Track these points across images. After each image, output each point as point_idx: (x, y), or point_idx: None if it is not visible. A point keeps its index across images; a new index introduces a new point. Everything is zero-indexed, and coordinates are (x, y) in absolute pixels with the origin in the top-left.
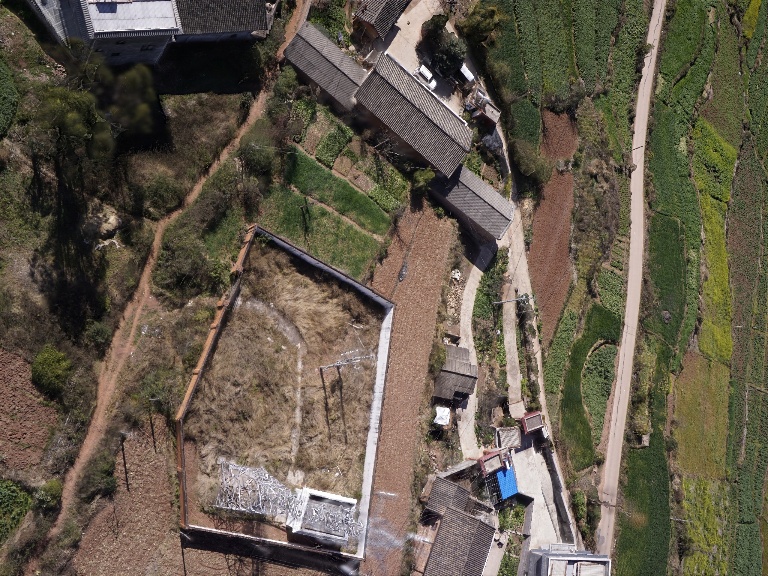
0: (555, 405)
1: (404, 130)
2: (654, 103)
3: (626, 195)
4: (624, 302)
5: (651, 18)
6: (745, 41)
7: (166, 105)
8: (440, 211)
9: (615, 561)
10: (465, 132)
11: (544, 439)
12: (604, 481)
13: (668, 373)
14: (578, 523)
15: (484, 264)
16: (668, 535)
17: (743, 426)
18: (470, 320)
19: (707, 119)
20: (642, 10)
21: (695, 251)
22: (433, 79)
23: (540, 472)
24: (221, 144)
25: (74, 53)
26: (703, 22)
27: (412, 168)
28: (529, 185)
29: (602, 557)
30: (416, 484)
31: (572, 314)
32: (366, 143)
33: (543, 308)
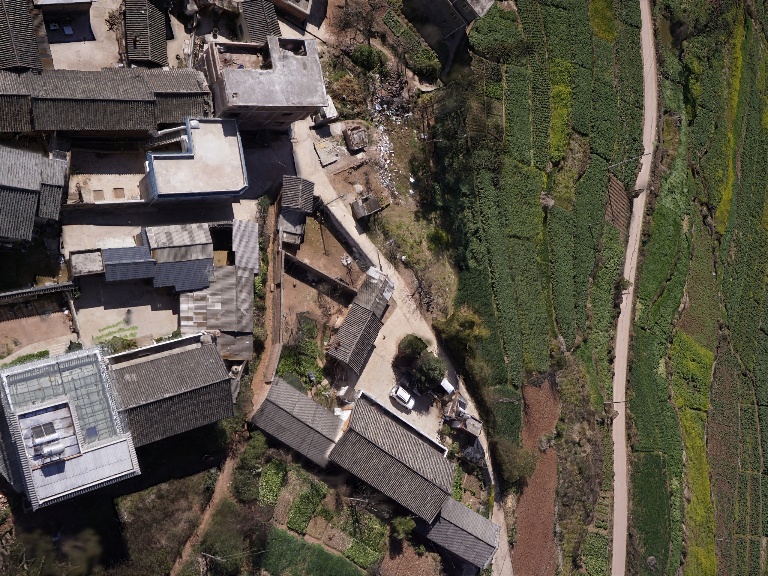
0: None
1: (382, 482)
2: (633, 337)
3: (609, 447)
4: (610, 564)
5: (627, 246)
6: (718, 237)
7: (122, 508)
8: (421, 551)
9: None
10: (446, 467)
11: None
12: None
13: None
14: None
15: None
16: None
17: None
18: None
19: (684, 329)
20: (618, 240)
21: (677, 479)
22: (411, 398)
23: None
24: (183, 541)
25: (17, 489)
26: (678, 234)
27: (391, 514)
28: None
29: None
30: None
31: None
32: (341, 494)
33: None
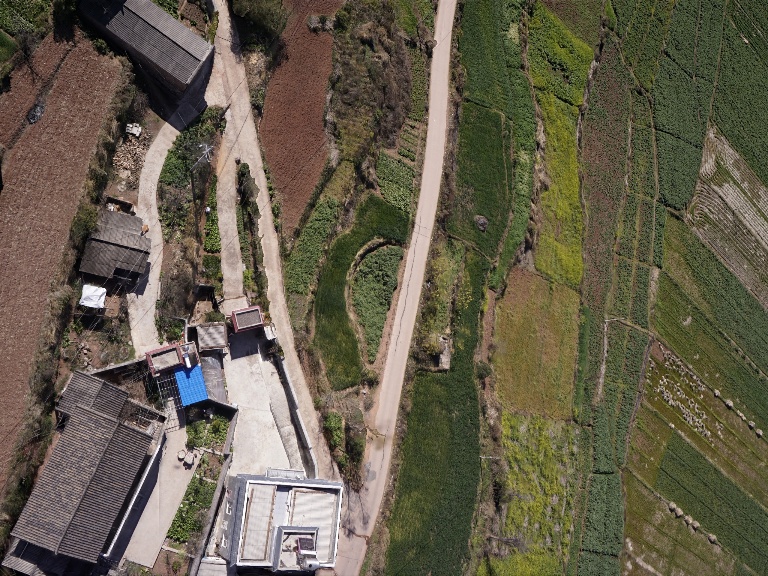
0: (302, 308)
1: None
2: None
3: (421, 74)
4: (416, 198)
5: None
6: None
7: None
8: (99, 43)
9: (389, 501)
10: None
11: (272, 343)
12: (378, 405)
13: (483, 288)
14: (333, 452)
15: (183, 122)
16: (476, 476)
17: (600, 362)
18: (155, 187)
19: (551, 9)
20: None
21: (527, 153)
22: None
23: (269, 384)
24: None
25: None
26: None
27: None
28: (257, 36)
29: (332, 484)
30: (35, 376)
31: (330, 201)
32: None
33: (284, 189)
